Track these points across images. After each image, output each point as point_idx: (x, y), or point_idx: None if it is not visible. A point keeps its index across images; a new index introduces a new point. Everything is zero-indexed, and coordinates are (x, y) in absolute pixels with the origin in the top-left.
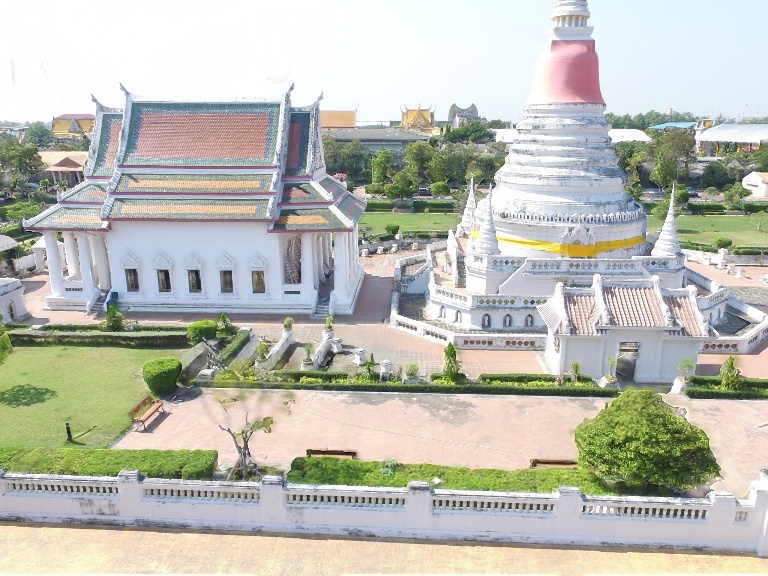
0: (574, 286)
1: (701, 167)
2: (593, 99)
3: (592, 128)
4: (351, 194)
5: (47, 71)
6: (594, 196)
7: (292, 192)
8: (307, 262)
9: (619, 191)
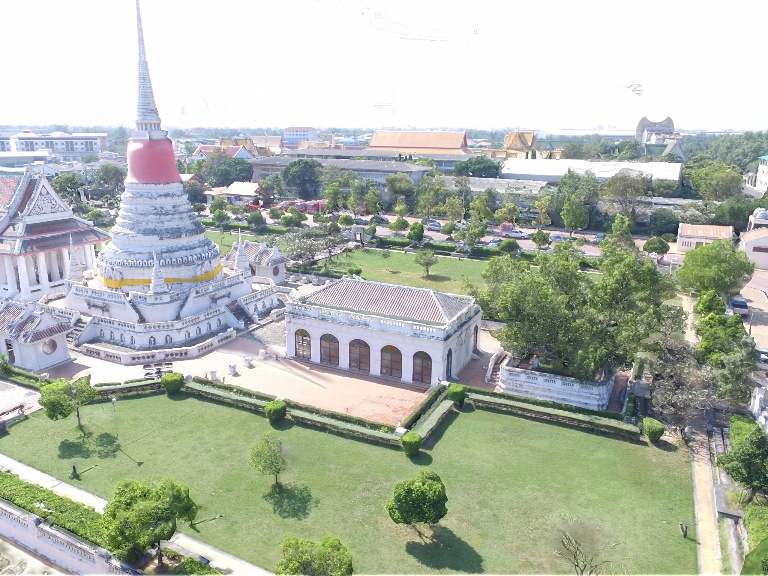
0: (92, 306)
1: (649, 213)
2: (146, 180)
3: (141, 200)
4: (97, 229)
5: (209, 104)
6: (133, 247)
7: (8, 229)
8: (8, 272)
9: (163, 245)
